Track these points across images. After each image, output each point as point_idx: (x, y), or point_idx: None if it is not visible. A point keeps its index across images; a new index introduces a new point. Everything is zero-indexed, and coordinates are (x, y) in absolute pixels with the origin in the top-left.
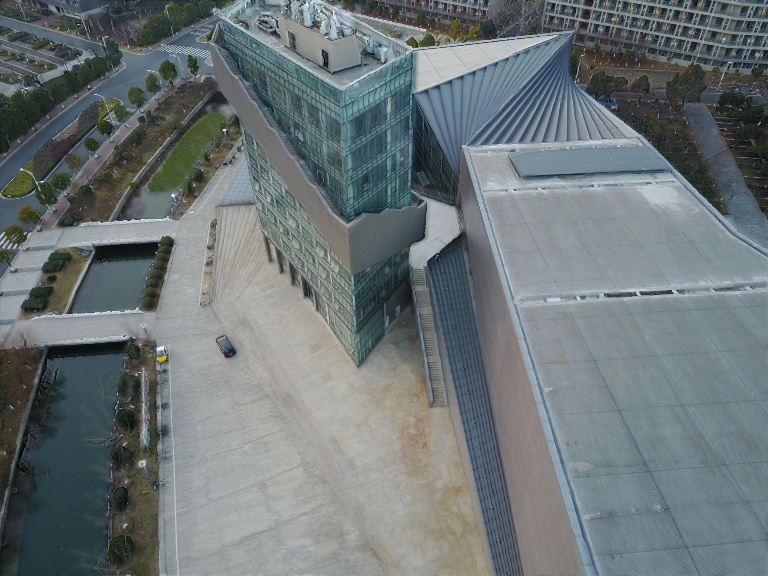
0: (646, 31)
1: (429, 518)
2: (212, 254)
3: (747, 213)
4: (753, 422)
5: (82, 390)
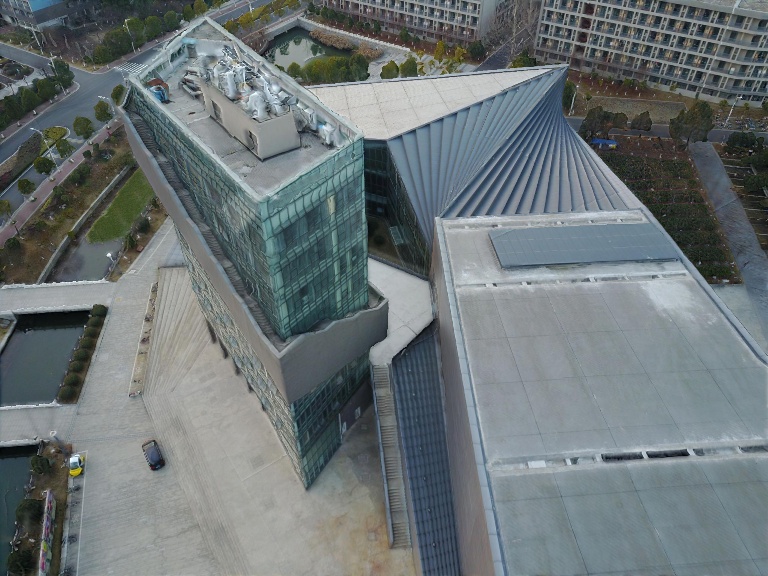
0: (647, 58)
1: None
2: (150, 328)
3: (761, 281)
4: None
5: None
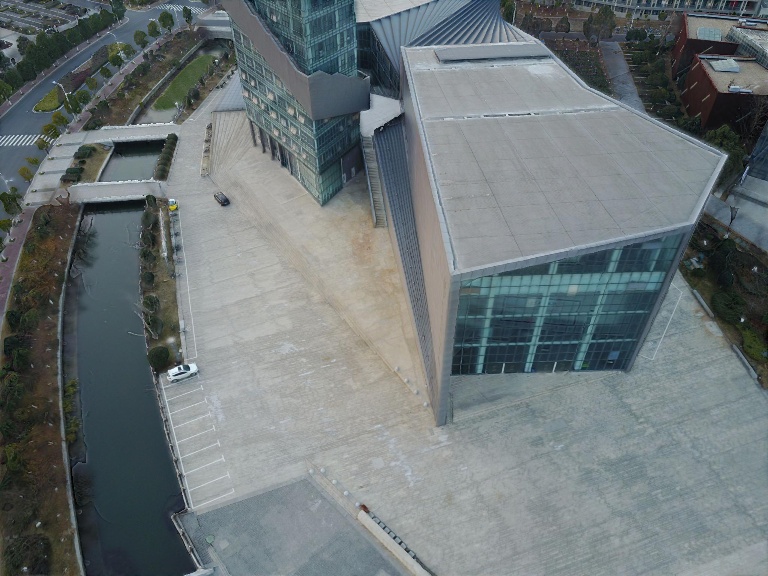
0: None
1: (369, 285)
2: (209, 145)
3: None
4: (559, 164)
5: (111, 238)
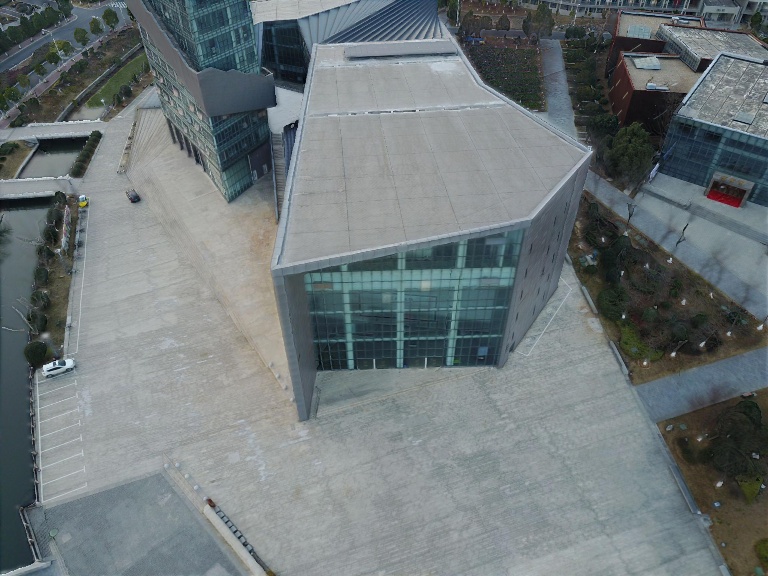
0: None
1: (260, 281)
2: (131, 142)
3: (561, 110)
4: (423, 160)
5: (24, 234)
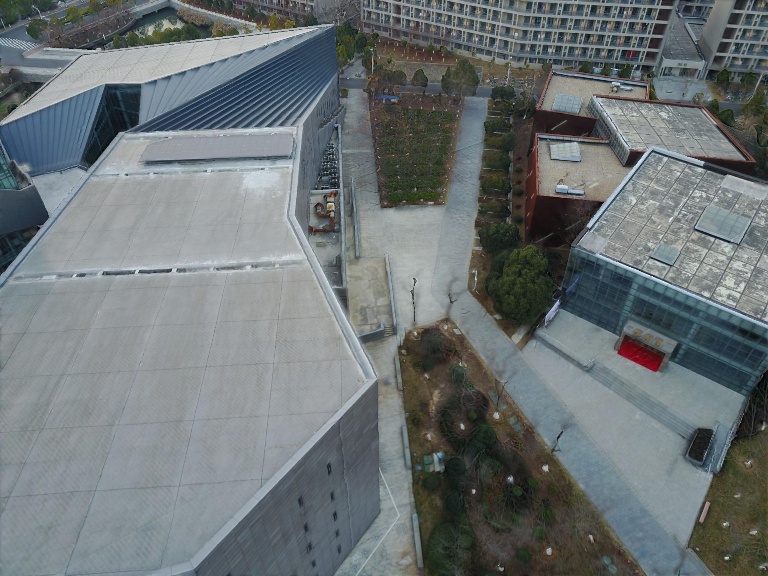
0: (450, 26)
1: None
2: None
3: (462, 203)
4: (112, 390)
5: None
